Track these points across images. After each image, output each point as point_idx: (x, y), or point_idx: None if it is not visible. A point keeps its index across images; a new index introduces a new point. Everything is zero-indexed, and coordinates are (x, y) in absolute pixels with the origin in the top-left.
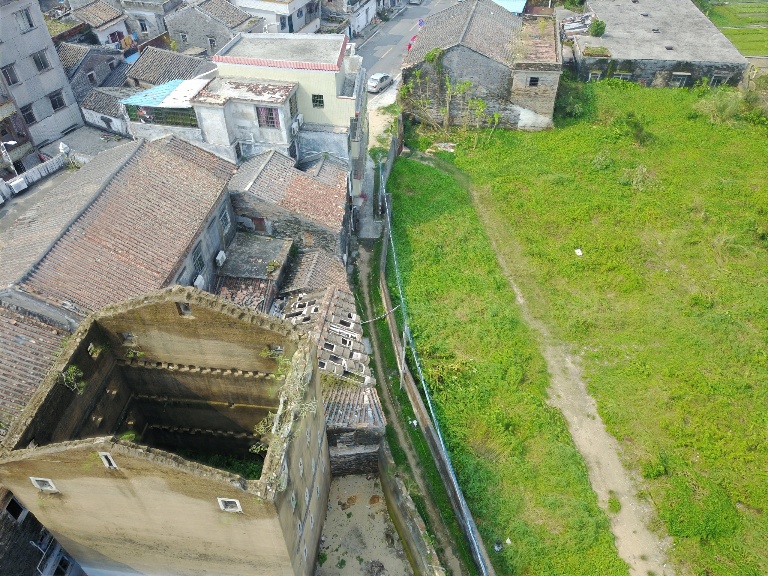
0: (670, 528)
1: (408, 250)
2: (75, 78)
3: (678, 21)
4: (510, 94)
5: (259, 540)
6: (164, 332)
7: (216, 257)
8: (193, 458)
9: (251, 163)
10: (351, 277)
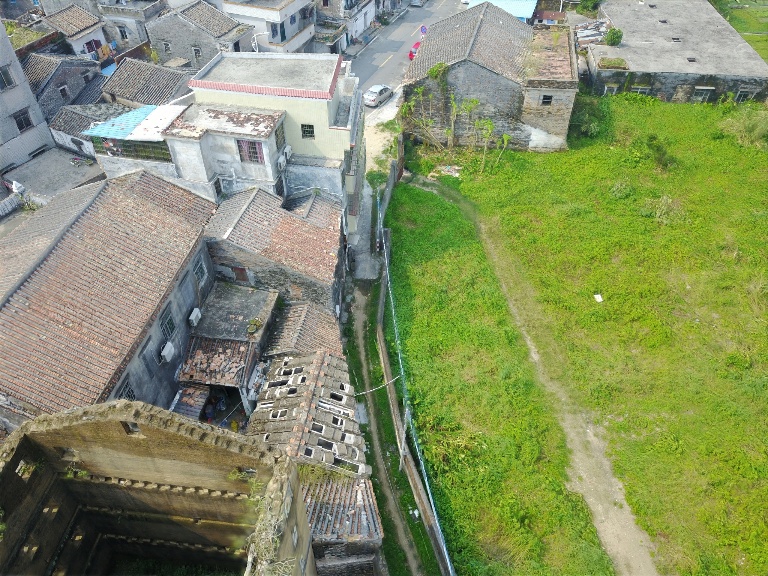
0: None
1: (409, 295)
2: (45, 94)
3: (699, 29)
4: (521, 113)
5: None
6: (110, 449)
7: (189, 316)
8: (156, 569)
9: (232, 202)
10: (345, 329)
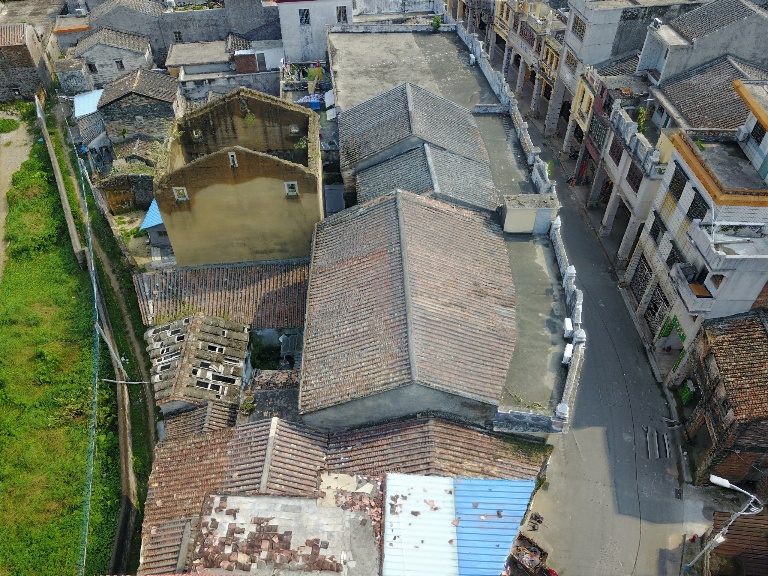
0: None
1: None
2: None
3: None
4: None
5: None
6: None
7: None
8: None
9: None
10: None
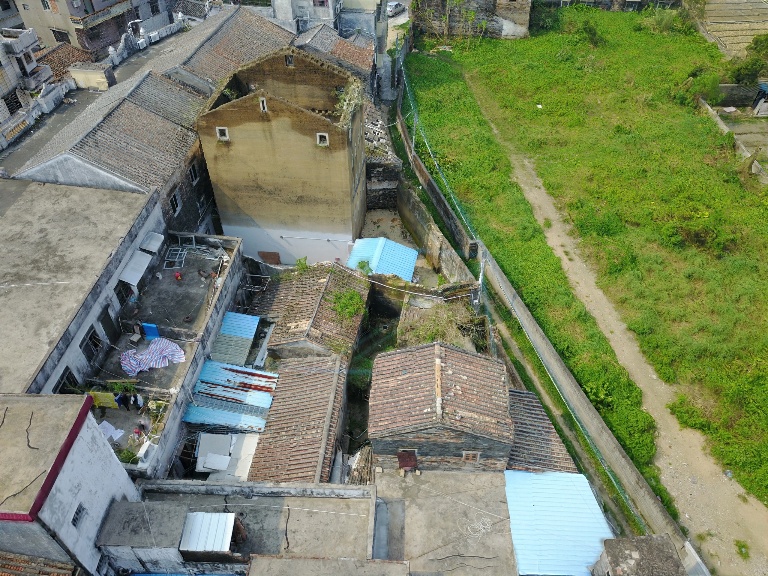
0: (580, 232)
1: (416, 104)
2: None
3: None
4: (495, 8)
5: (335, 175)
6: (275, 80)
7: None
8: None
9: (307, 33)
10: None
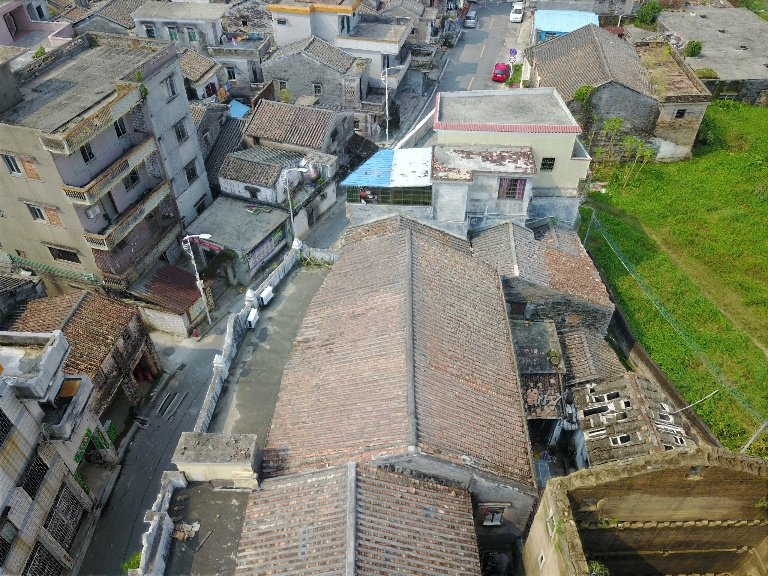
0: None
1: (629, 311)
2: None
3: (758, 36)
4: (654, 127)
5: None
6: (647, 494)
7: None
8: None
9: (488, 238)
10: None
